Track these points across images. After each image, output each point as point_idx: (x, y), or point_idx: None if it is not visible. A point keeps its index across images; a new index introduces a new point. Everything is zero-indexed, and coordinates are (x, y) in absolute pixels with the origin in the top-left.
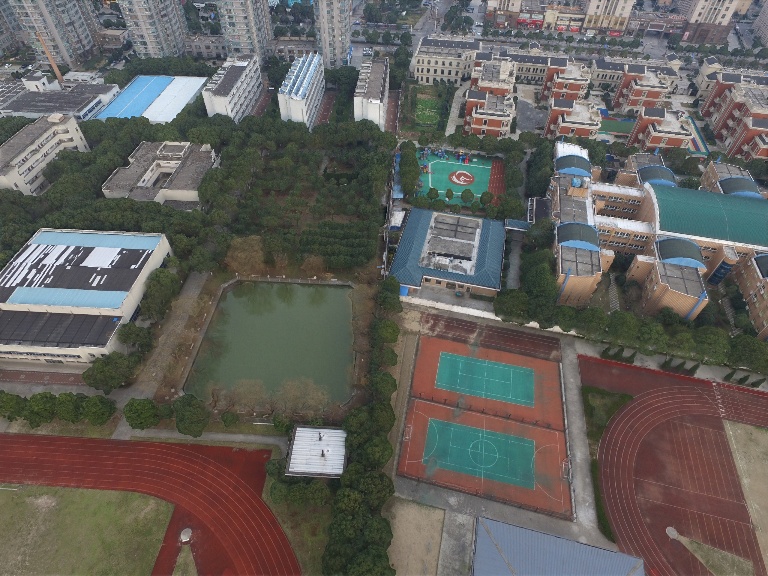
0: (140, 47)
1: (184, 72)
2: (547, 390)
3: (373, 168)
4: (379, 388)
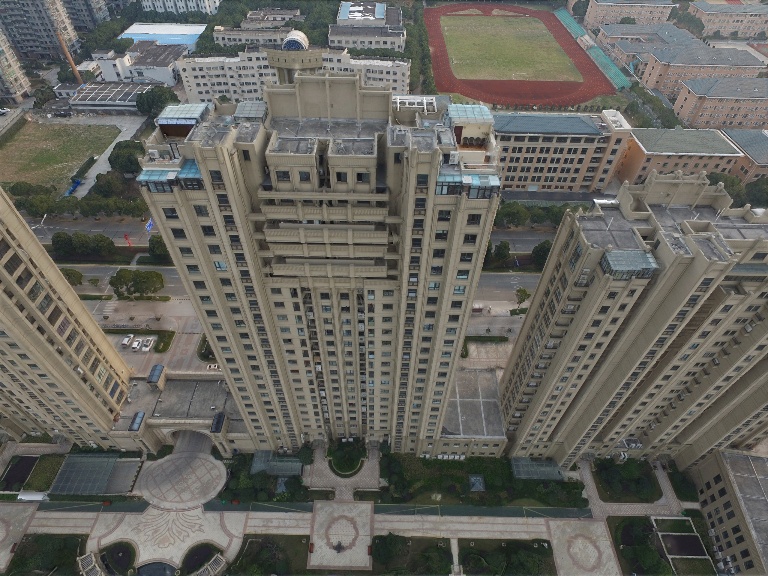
0: (64, 34)
1: (119, 29)
2: None
3: None
4: None
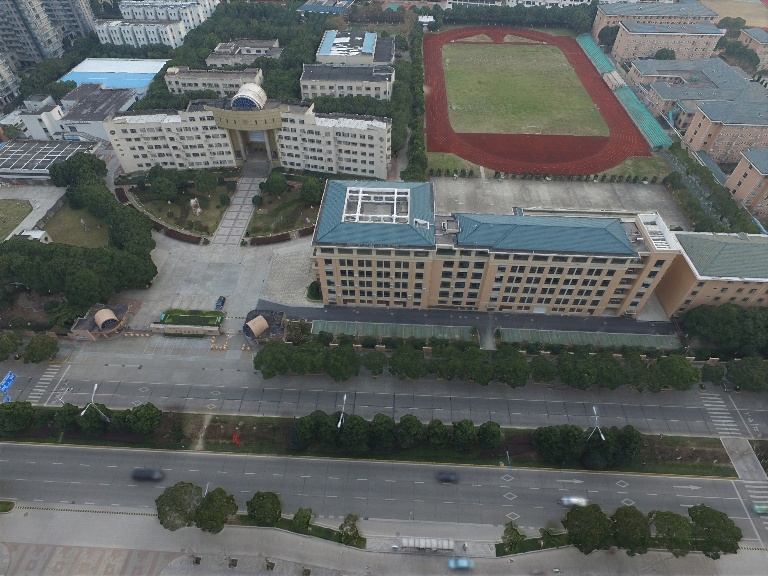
0: None
1: (66, 67)
2: (396, 3)
3: (271, 5)
4: (404, 9)
